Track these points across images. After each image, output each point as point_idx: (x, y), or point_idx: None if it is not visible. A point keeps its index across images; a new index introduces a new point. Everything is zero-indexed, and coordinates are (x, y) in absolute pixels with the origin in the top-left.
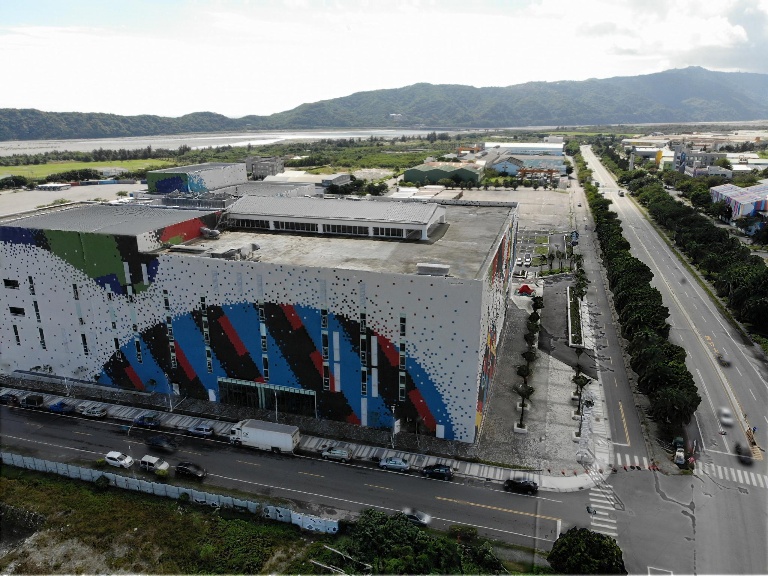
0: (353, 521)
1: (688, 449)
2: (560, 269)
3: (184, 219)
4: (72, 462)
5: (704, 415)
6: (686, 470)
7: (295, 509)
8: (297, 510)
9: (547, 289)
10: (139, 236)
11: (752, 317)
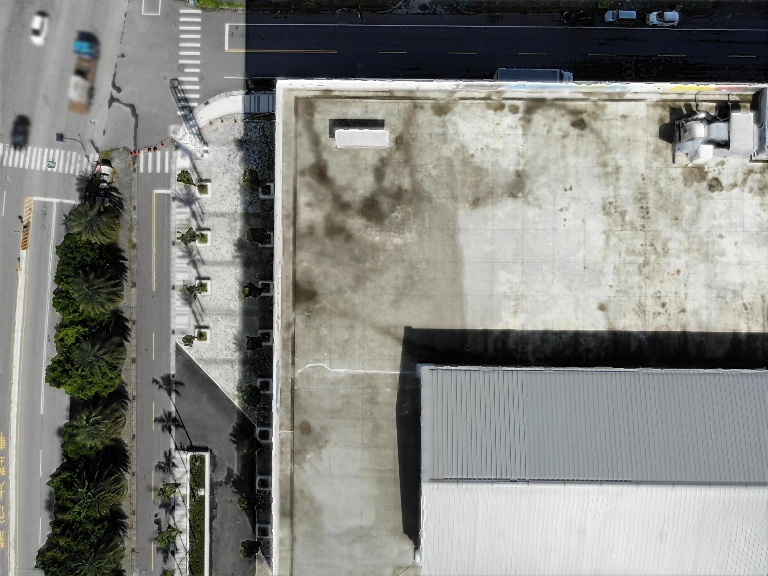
0: (401, 1)
1: None
2: None
3: None
4: (710, 8)
5: None
6: (105, 158)
7: (457, 1)
8: (455, 1)
9: None
10: None
11: None
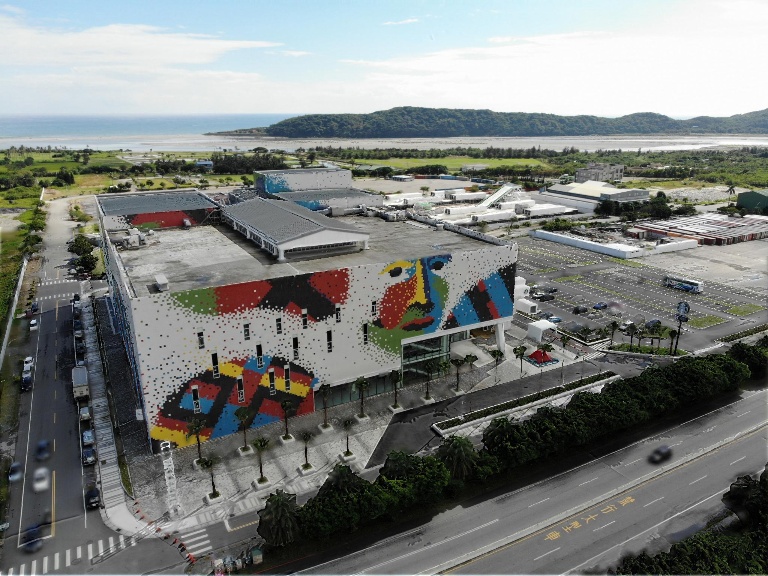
0: (2, 454)
1: (256, 569)
2: (658, 349)
3: (175, 210)
4: None
5: (361, 559)
6: None
7: (6, 431)
8: (5, 432)
9: (579, 365)
10: (106, 217)
11: (725, 504)
